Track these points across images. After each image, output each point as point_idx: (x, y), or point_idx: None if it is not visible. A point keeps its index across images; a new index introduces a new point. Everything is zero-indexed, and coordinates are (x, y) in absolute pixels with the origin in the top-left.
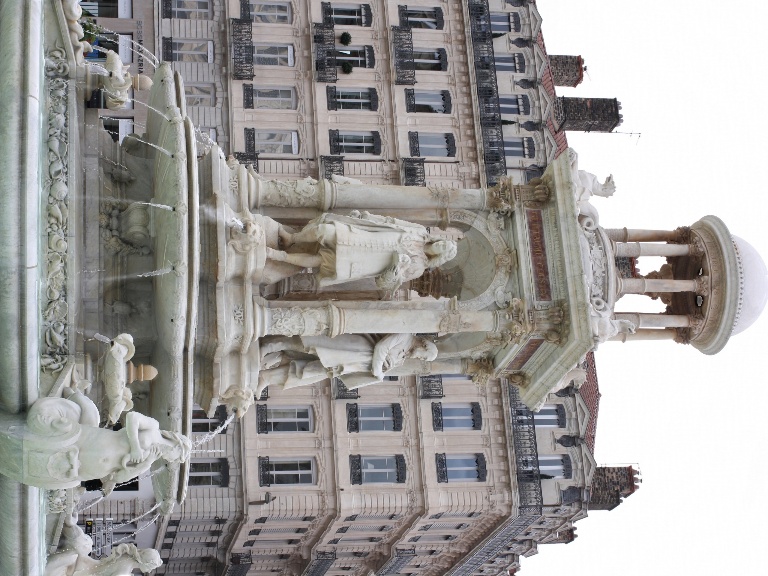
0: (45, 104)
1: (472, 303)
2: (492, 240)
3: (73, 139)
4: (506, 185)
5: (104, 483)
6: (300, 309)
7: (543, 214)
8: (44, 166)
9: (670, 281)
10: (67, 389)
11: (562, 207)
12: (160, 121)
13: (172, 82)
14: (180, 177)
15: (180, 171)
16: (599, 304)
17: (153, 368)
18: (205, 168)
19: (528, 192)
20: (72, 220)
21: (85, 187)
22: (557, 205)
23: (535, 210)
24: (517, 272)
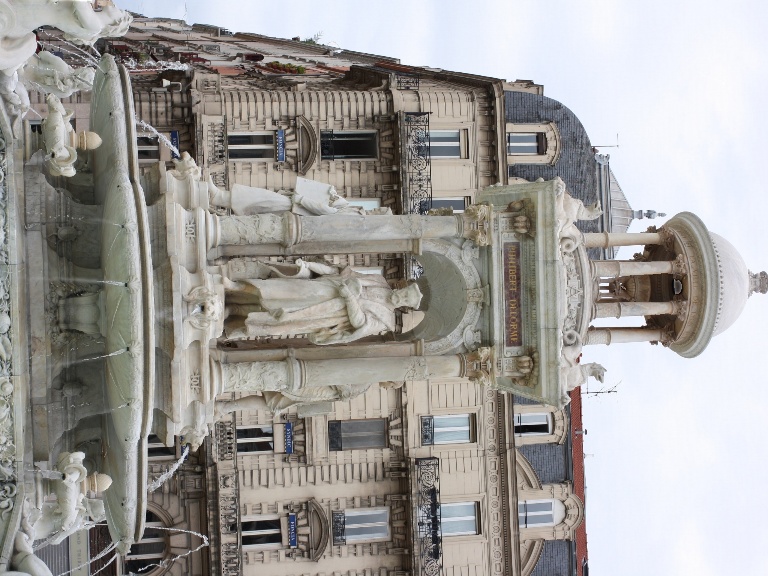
0: None
1: None
2: None
3: None
4: None
5: (50, 110)
6: None
7: None
8: None
9: None
10: None
11: None
12: None
13: None
14: None
15: None
16: None
17: None
18: None
19: None
20: None
21: None
22: None
23: None
24: None
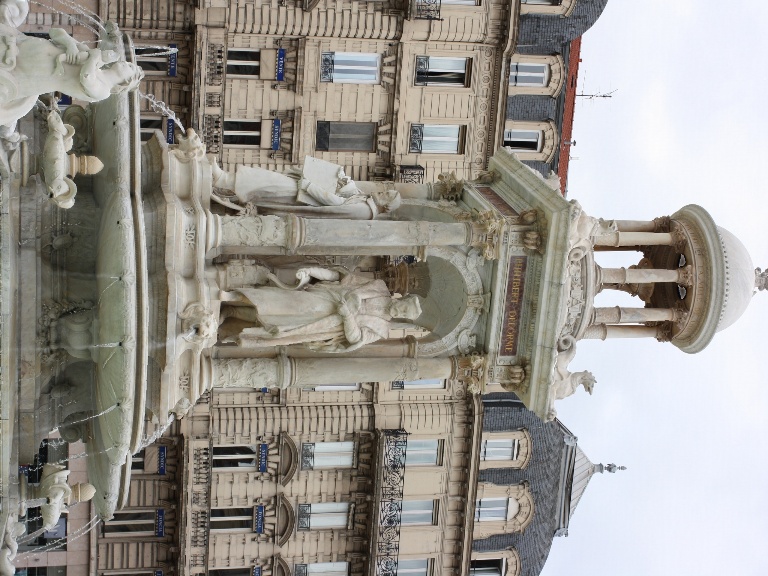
0: None
1: None
2: None
3: None
4: None
5: None
6: None
7: None
8: None
9: None
10: None
11: None
12: None
13: None
14: None
15: None
16: None
17: None
18: None
19: None
20: None
21: None
22: None
23: None
24: None
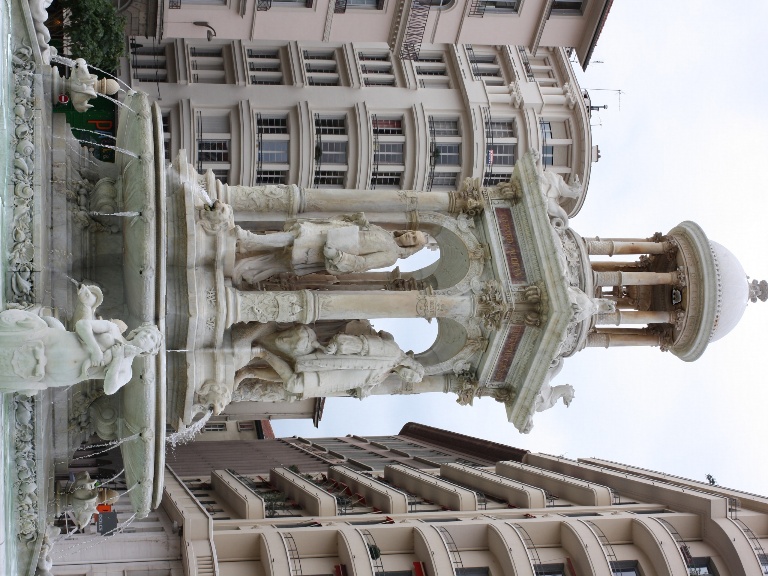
0: (11, 438)
1: (430, 368)
2: (469, 329)
3: (41, 457)
4: (499, 311)
5: None
6: (261, 391)
7: (527, 329)
8: (13, 474)
9: (634, 343)
10: (40, 565)
11: (544, 344)
12: (135, 310)
13: (152, 276)
14: (145, 498)
15: (146, 494)
16: (554, 362)
17: (115, 499)
18: (181, 323)
19: (520, 315)
20: (42, 502)
21: (54, 413)
22: (541, 339)
23: (520, 326)
24: (483, 353)
